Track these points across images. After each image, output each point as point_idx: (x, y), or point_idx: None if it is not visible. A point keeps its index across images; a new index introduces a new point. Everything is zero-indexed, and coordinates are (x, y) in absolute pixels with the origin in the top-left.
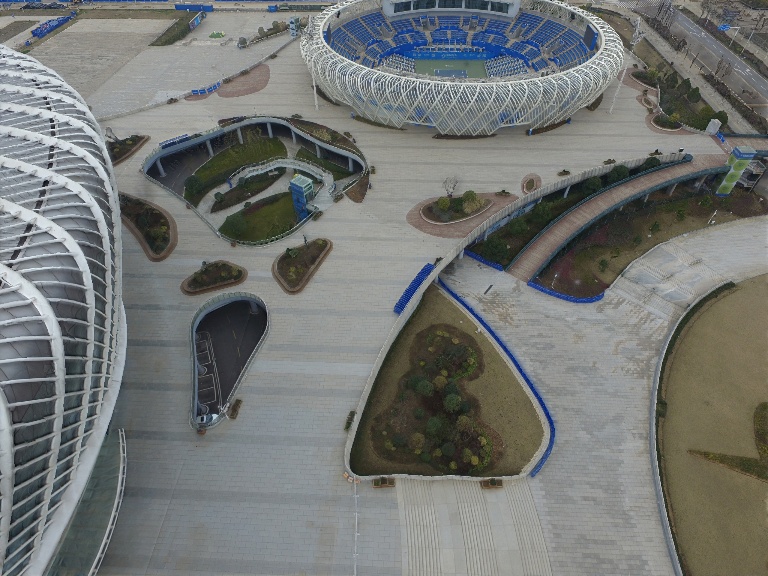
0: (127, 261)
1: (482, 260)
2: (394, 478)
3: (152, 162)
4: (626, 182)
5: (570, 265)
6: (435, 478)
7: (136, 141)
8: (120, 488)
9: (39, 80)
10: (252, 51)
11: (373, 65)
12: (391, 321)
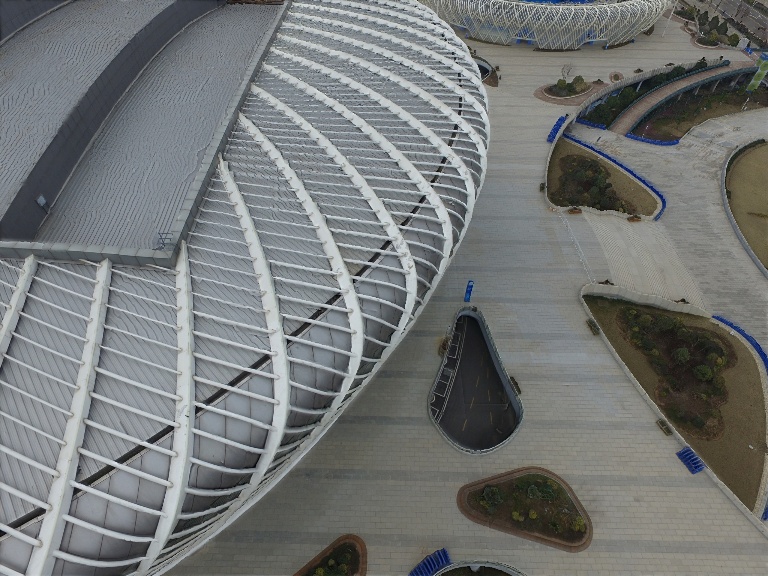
0: None
1: (590, 124)
2: (580, 209)
3: None
4: (683, 78)
5: (651, 127)
6: (603, 212)
7: None
8: None
9: None
10: None
11: None
12: (547, 146)
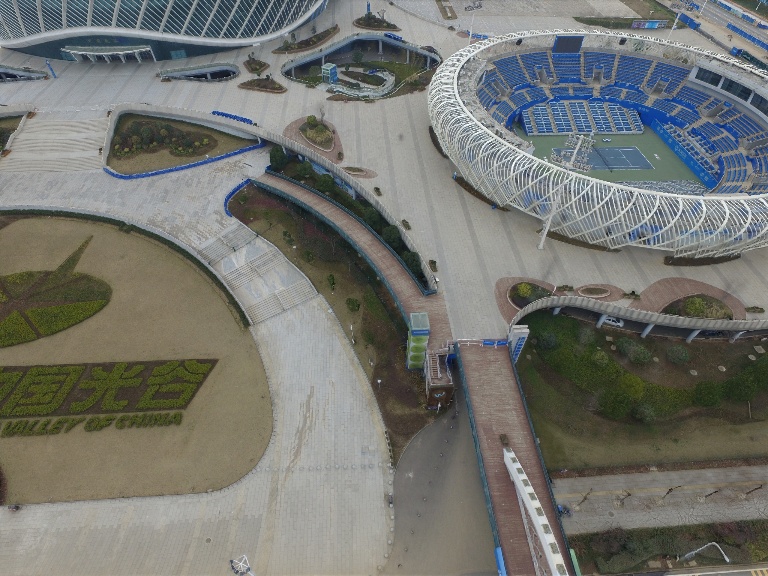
0: (273, 46)
1: None
2: None
3: (373, 38)
4: (379, 240)
5: (272, 207)
6: None
7: (390, 27)
8: (125, 52)
9: None
10: None
11: (587, 98)
12: None
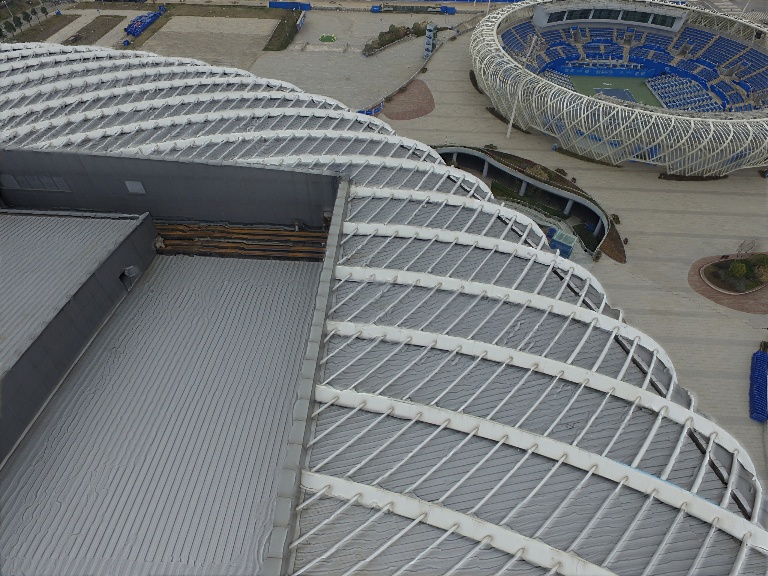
0: None
1: None
2: None
3: None
4: None
5: None
6: None
7: None
8: None
9: (406, 145)
10: (381, 60)
11: None
12: (755, 431)
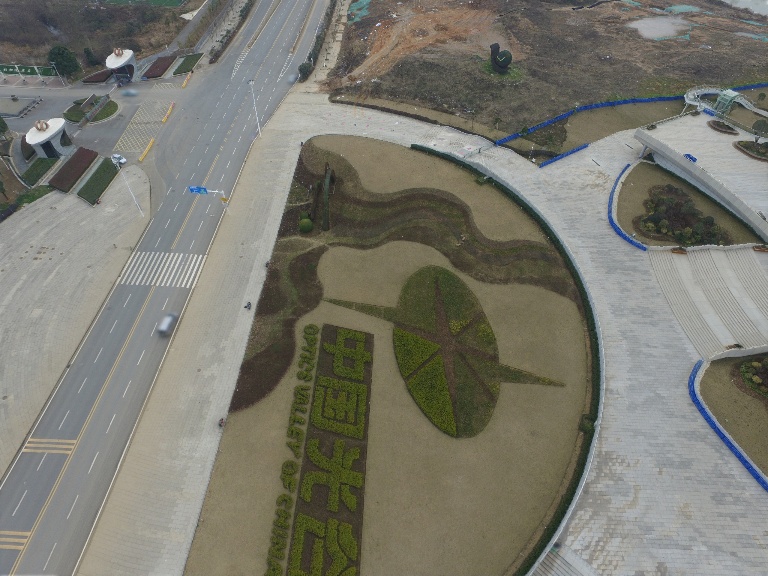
0: None
1: None
2: None
3: None
4: None
5: None
6: None
7: None
8: None
9: None
10: None
11: None
12: None
